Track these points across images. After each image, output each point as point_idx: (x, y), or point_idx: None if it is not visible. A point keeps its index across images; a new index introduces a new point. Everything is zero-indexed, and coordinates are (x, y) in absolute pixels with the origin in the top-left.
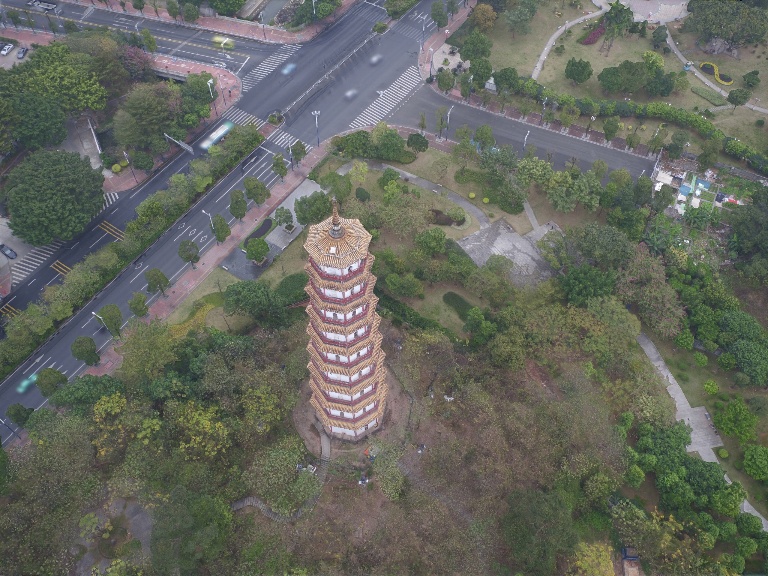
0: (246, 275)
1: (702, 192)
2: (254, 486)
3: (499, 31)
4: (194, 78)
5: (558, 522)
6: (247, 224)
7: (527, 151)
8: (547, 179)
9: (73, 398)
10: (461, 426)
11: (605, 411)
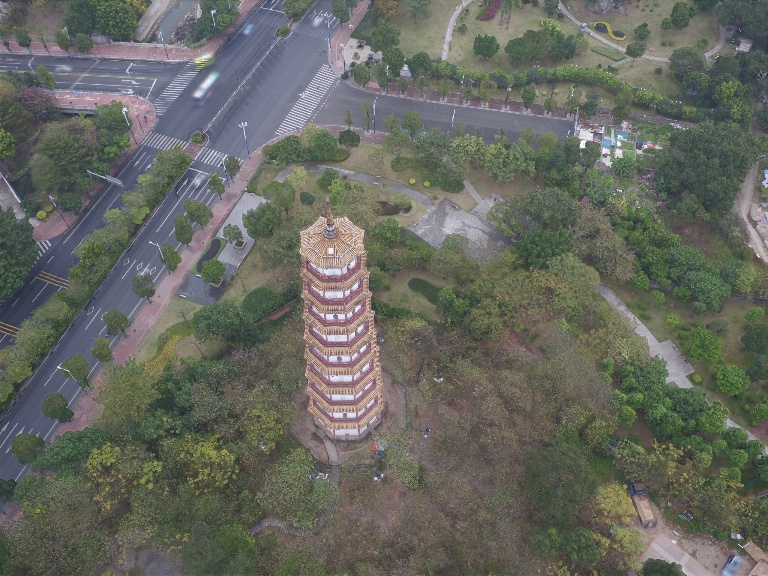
0: (206, 299)
1: (622, 143)
2: (270, 506)
3: (400, 19)
4: (105, 109)
5: (581, 471)
6: (195, 248)
7: (454, 130)
8: (482, 154)
9: (60, 458)
10: (457, 404)
11: (591, 360)
